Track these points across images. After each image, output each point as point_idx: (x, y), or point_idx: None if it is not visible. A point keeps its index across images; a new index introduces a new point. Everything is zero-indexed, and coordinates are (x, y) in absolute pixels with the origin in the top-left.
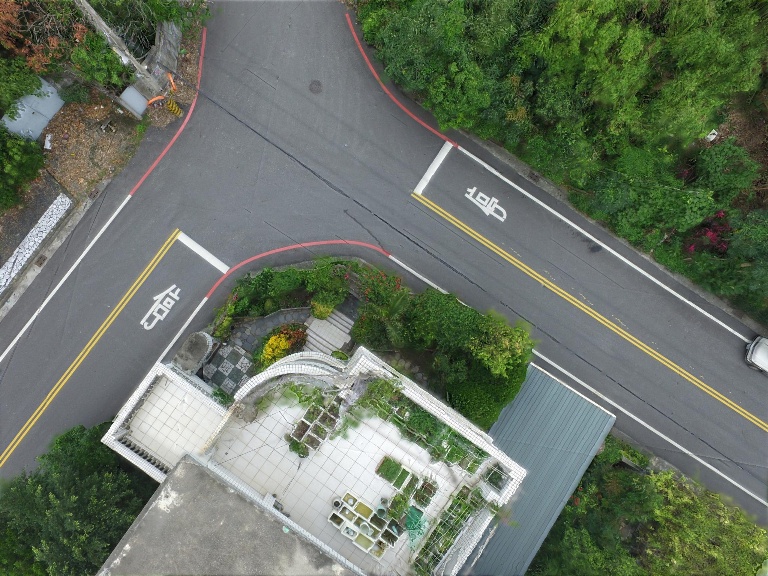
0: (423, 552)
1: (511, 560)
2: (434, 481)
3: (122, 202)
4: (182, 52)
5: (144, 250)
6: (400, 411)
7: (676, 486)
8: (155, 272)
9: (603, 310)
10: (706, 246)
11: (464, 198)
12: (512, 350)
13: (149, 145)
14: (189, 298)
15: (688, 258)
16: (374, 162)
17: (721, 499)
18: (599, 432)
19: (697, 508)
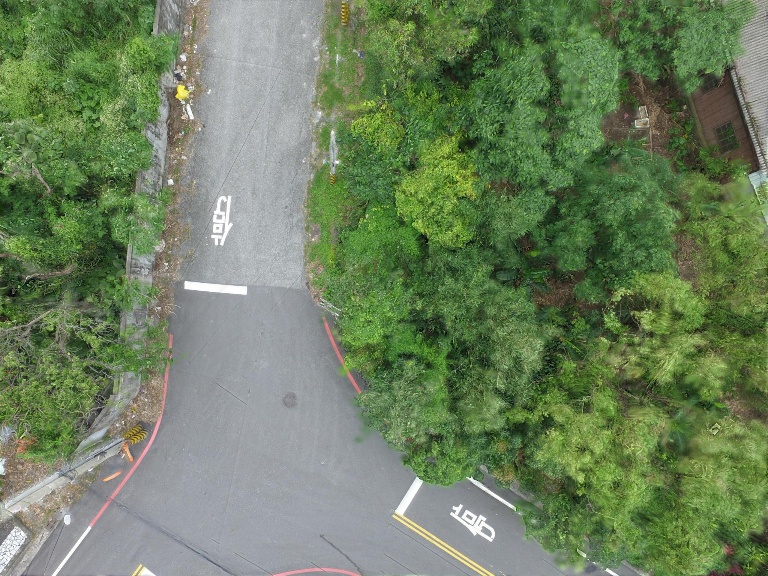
0: None
1: None
2: None
3: (81, 535)
4: None
5: None
6: None
7: None
8: None
9: None
10: None
11: (449, 517)
12: None
13: (110, 469)
14: None
15: None
16: (353, 481)
17: None
18: None
19: None
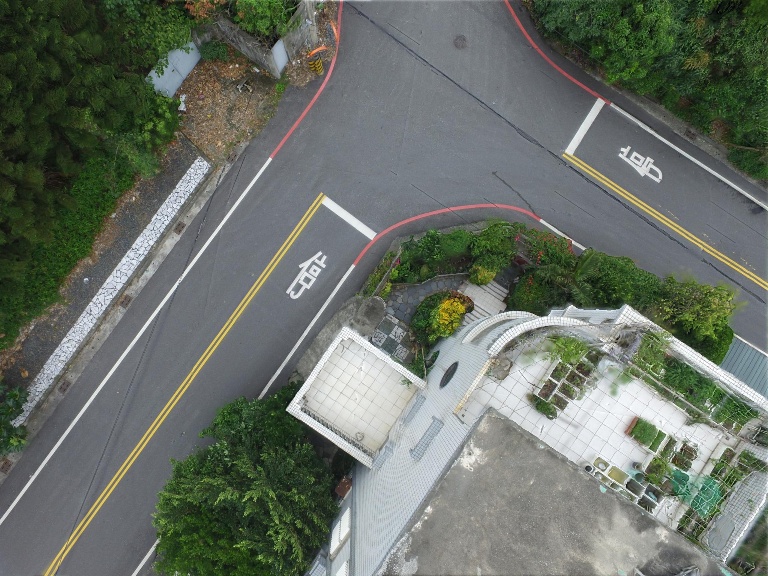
0: (685, 520)
1: None
2: (695, 443)
3: (262, 165)
4: (319, 7)
5: (287, 215)
6: (655, 368)
7: None
8: (300, 238)
9: (766, 275)
10: None
11: (618, 158)
12: (718, 310)
13: (288, 105)
14: (336, 265)
15: None
16: (523, 121)
17: None
18: None
19: None
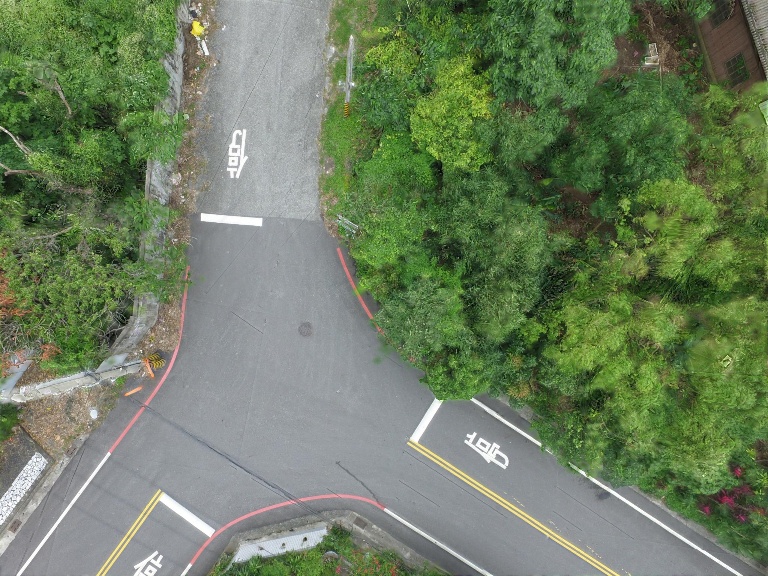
0: None
1: None
2: None
3: (101, 461)
4: (164, 293)
5: (124, 514)
6: None
7: None
8: (136, 538)
9: (612, 564)
10: None
11: (463, 444)
12: None
13: None
14: (172, 565)
15: (702, 512)
16: (368, 409)
17: None
18: None
19: None
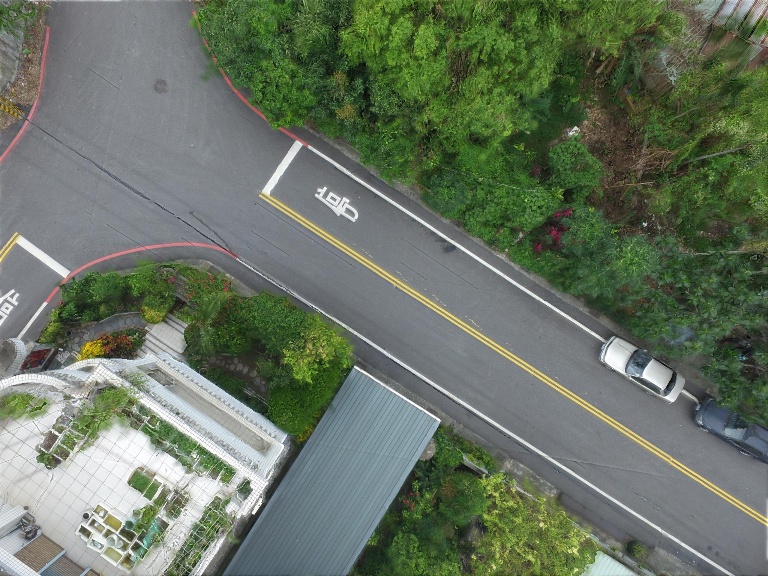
0: (173, 564)
1: (329, 567)
2: (185, 491)
3: None
4: (24, 52)
5: None
6: (152, 420)
7: (505, 490)
8: None
9: (456, 311)
10: (554, 245)
11: (314, 198)
12: (319, 354)
13: None
14: (28, 303)
15: None
16: (221, 163)
17: (577, 501)
18: (422, 436)
19: (519, 512)
